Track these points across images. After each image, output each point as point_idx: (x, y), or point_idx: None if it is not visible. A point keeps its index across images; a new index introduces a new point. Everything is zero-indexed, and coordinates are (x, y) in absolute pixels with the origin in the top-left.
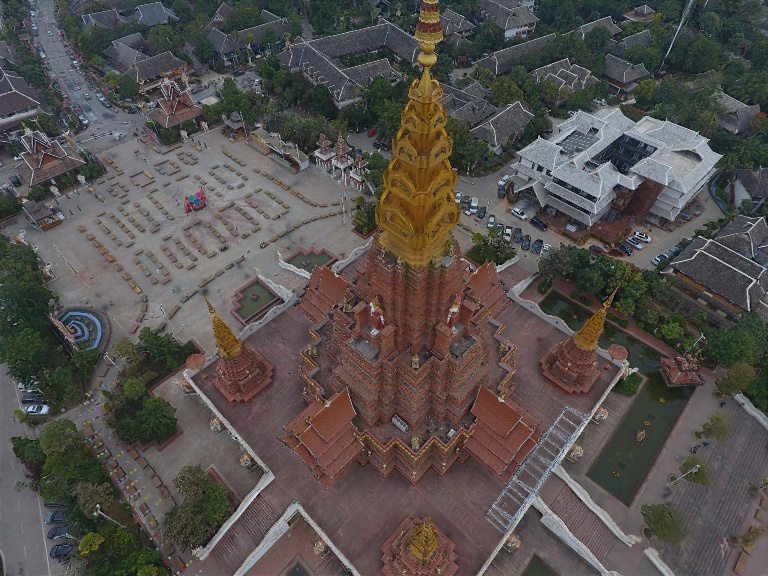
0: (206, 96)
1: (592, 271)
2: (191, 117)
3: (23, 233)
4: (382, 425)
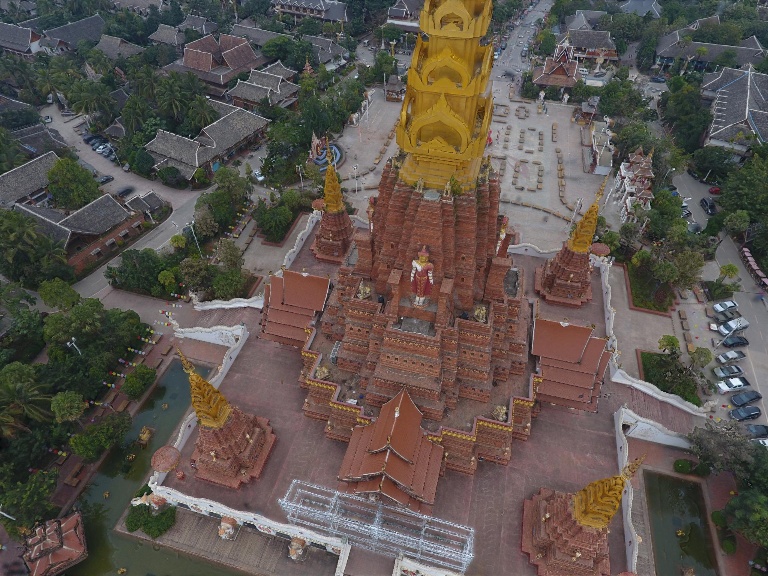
0: (597, 79)
1: (767, 506)
2: (561, 85)
3: (373, 92)
4: (330, 341)
